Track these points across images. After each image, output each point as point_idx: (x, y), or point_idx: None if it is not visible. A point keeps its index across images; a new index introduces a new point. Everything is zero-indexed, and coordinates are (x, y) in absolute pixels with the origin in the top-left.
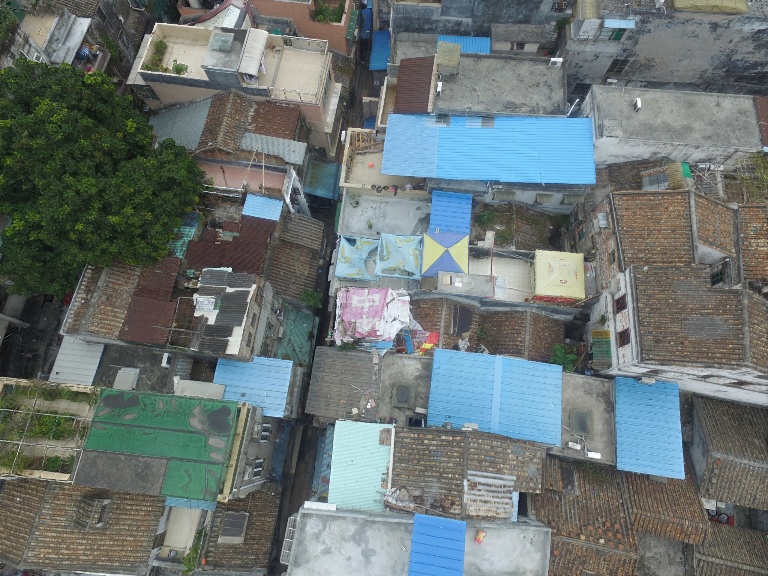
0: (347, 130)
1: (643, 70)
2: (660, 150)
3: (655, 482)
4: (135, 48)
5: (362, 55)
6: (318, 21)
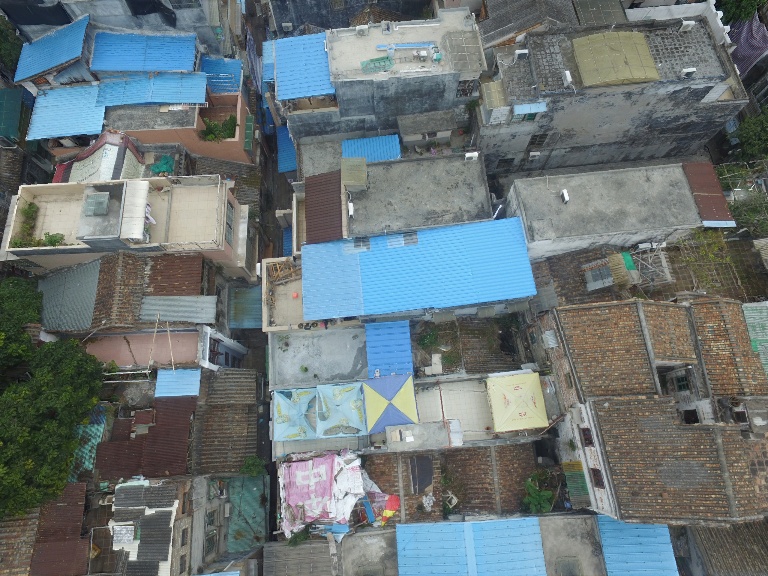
0: (261, 262)
1: (564, 139)
2: (597, 240)
3: None
4: (14, 193)
5: (271, 147)
6: (209, 140)
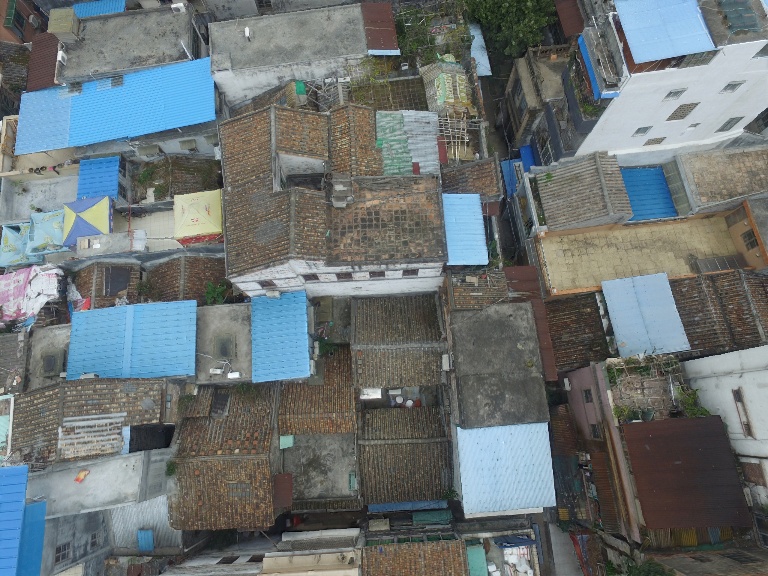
0: (3, 119)
1: None
2: (280, 74)
3: (314, 386)
4: None
5: None
6: None
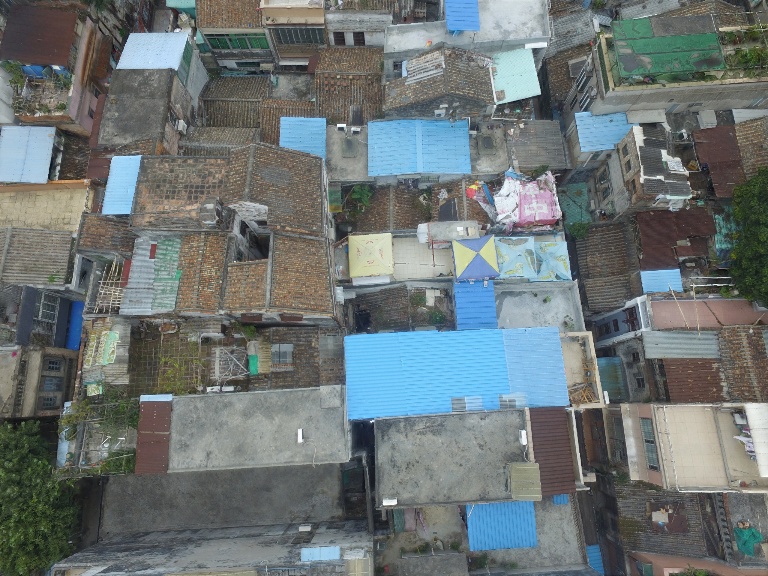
0: None
1: (271, 541)
2: None
3: None
4: None
5: None
6: None
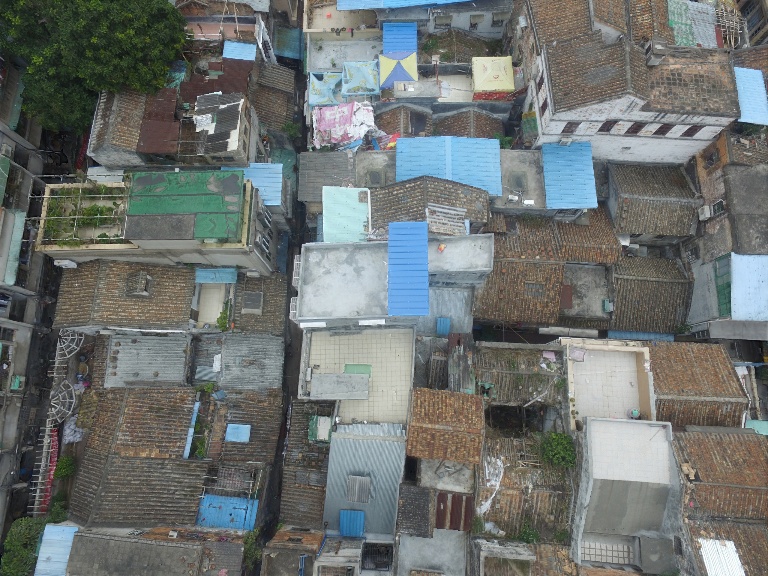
0: None
1: None
2: None
3: (580, 226)
4: None
5: None
6: None
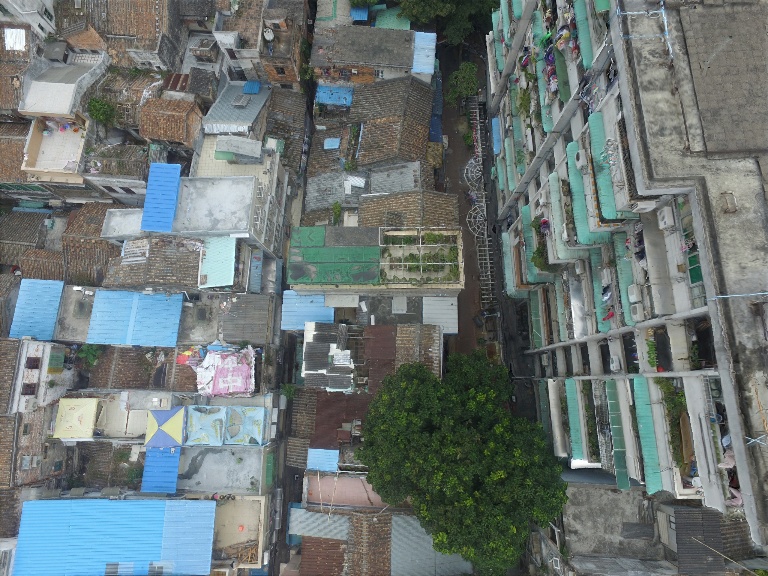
0: None
1: None
2: None
3: None
4: None
5: None
6: None
